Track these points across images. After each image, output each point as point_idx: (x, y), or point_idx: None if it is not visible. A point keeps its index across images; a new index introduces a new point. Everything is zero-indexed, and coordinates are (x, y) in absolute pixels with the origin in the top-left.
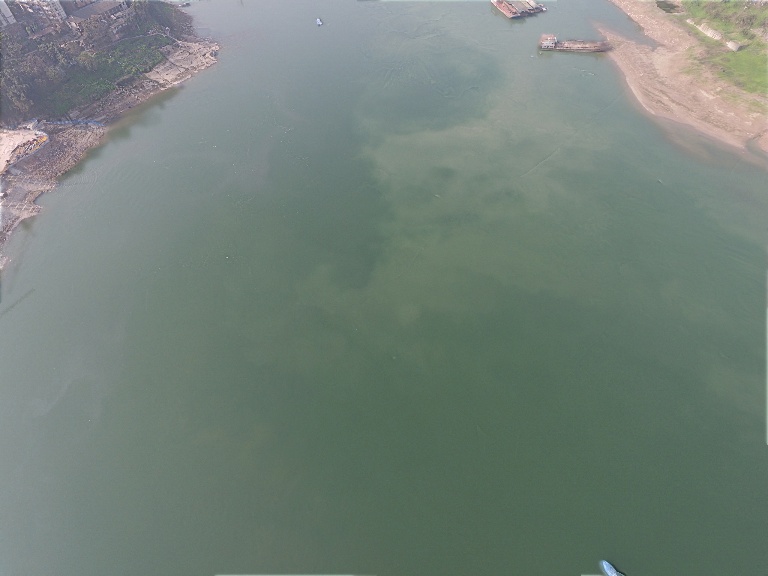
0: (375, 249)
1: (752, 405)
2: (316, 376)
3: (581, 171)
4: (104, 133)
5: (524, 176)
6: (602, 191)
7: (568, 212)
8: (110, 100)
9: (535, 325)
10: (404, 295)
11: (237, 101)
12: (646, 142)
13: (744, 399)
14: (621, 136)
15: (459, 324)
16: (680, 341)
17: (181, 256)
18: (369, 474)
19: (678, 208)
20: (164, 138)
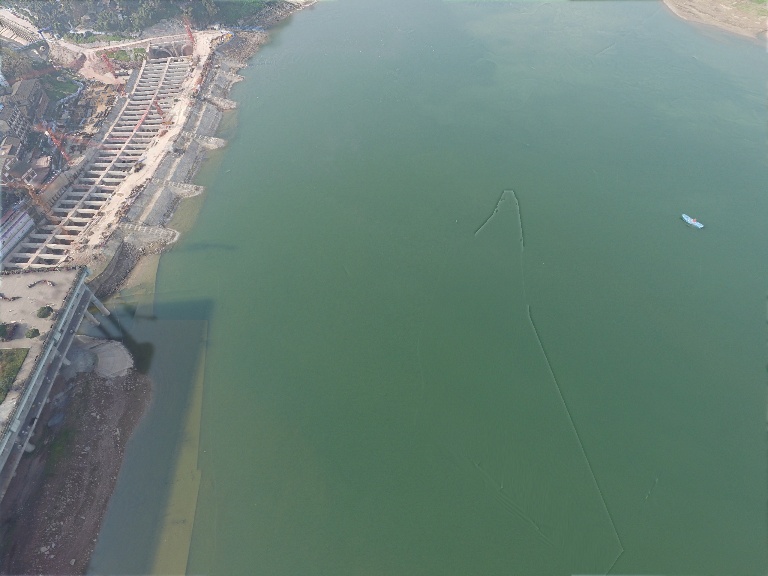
0: (497, 95)
1: (765, 159)
2: (480, 152)
3: (636, 54)
4: (266, 36)
5: (595, 56)
6: (653, 64)
7: (630, 75)
8: (263, 15)
9: (618, 129)
10: (527, 114)
11: (361, 16)
12: (682, 36)
13: (760, 157)
14: (663, 32)
15: (567, 129)
16: (716, 135)
17: (361, 99)
18: (529, 191)
19: (709, 71)
20: (315, 38)
